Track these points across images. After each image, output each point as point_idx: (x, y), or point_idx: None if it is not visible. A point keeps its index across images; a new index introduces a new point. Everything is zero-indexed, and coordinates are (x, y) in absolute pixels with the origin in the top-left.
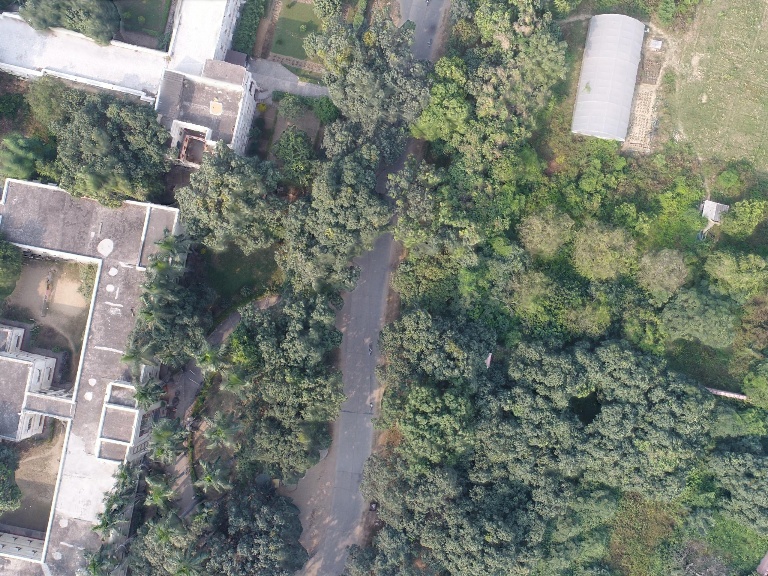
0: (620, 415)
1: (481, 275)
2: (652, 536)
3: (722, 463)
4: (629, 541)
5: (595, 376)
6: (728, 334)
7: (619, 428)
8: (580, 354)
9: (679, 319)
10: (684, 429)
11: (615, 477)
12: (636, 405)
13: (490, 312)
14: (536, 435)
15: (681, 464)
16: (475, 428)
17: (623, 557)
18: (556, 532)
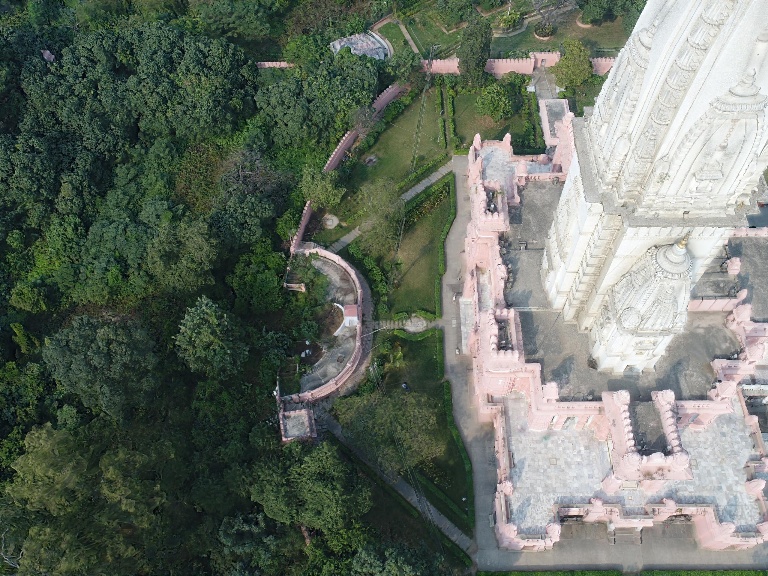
0: (150, 52)
1: (54, 19)
2: (217, 176)
3: (259, 91)
4: (194, 182)
5: (134, 42)
6: (262, 23)
7: (149, 60)
8: (120, 29)
9: (210, 8)
10: (213, 61)
11: (160, 112)
12: (171, 54)
13: (60, 39)
14: (79, 82)
15: (217, 90)
16: (19, 80)
17: (188, 194)
18: (116, 178)
